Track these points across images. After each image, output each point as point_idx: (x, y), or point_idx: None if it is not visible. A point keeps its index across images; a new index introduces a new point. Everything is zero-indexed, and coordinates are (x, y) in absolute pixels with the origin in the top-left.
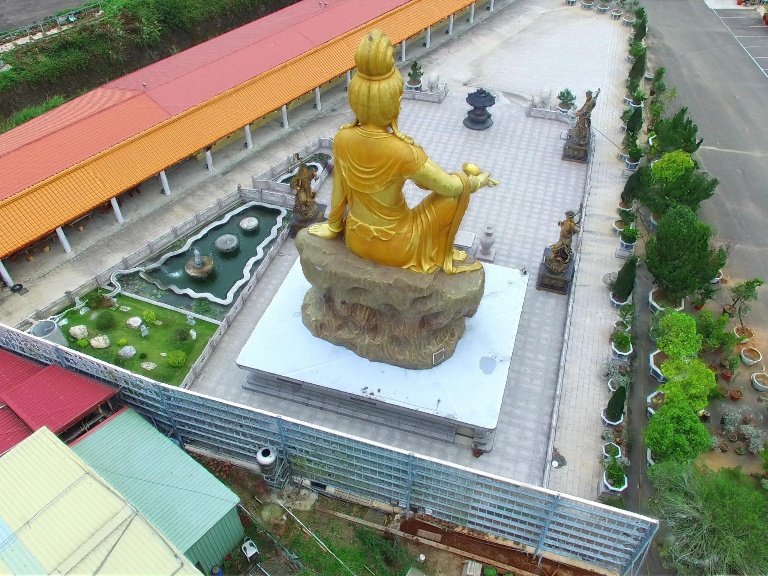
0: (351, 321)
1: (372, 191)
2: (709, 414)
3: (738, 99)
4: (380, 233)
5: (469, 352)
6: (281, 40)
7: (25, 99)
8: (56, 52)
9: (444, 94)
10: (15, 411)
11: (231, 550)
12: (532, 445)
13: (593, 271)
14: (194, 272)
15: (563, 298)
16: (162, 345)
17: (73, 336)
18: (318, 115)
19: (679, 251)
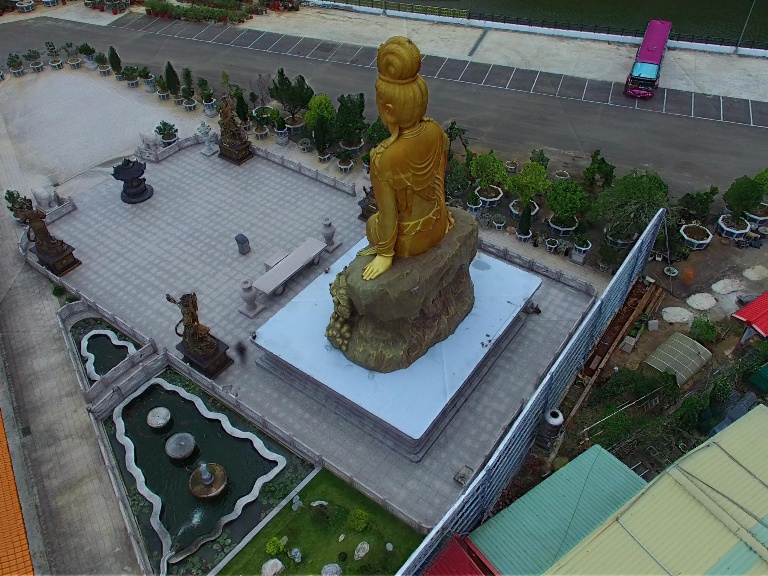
0: None
1: (432, 179)
2: None
3: (235, 65)
4: (436, 215)
5: None
6: None
7: None
8: None
9: (62, 202)
10: None
11: None
12: None
13: None
14: (219, 487)
15: None
16: (324, 540)
17: None
18: None
19: None
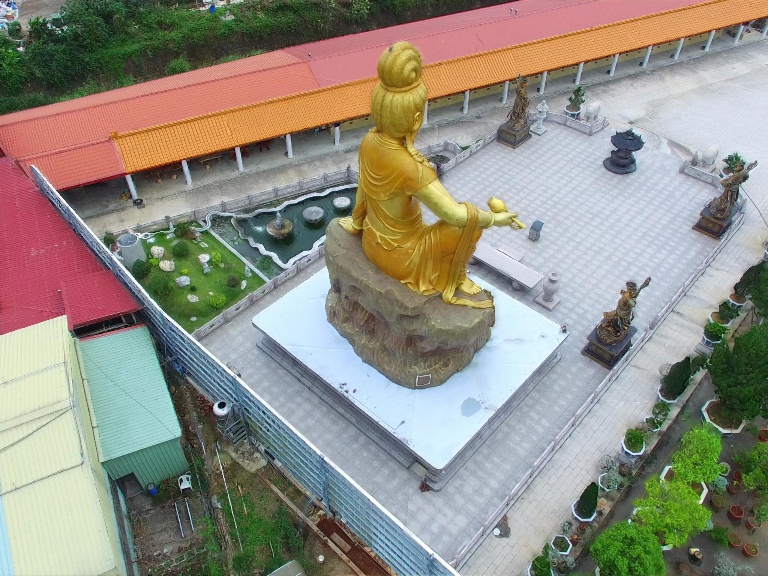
0: (354, 317)
1: (378, 198)
2: (700, 556)
3: None
4: (383, 241)
5: (459, 388)
6: (454, 38)
7: (237, 47)
8: (274, 12)
9: (600, 127)
10: (63, 296)
11: (172, 476)
12: (483, 503)
13: (658, 356)
14: (272, 231)
15: (605, 372)
16: (215, 285)
17: (152, 254)
18: (461, 118)
19: (748, 366)
